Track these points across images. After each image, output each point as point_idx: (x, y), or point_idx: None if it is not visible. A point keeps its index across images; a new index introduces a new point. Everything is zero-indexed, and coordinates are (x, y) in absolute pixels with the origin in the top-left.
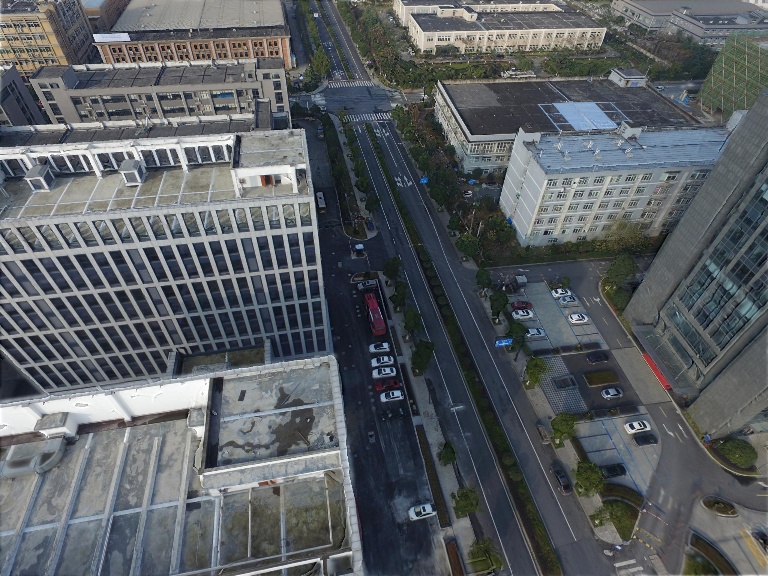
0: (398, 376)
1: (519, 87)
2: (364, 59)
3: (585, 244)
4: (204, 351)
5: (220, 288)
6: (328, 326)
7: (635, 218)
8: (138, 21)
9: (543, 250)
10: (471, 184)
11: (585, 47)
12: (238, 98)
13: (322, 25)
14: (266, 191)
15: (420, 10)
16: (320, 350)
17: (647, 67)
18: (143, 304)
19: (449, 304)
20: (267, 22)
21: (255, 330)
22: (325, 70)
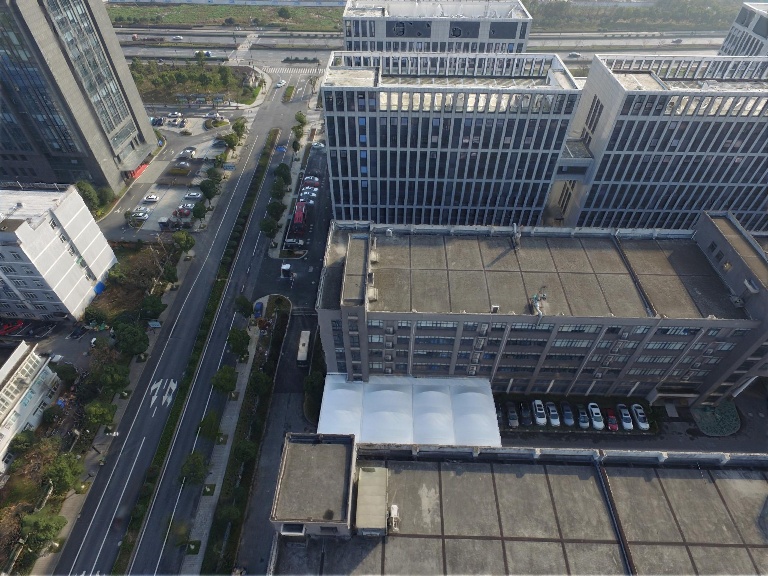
0: None
1: None
2: None
3: None
4: None
5: None
6: None
7: None
8: None
9: None
10: None
11: None
12: None
13: None
14: None
15: None
16: None
17: None
18: None
19: None
20: None
21: None
22: None
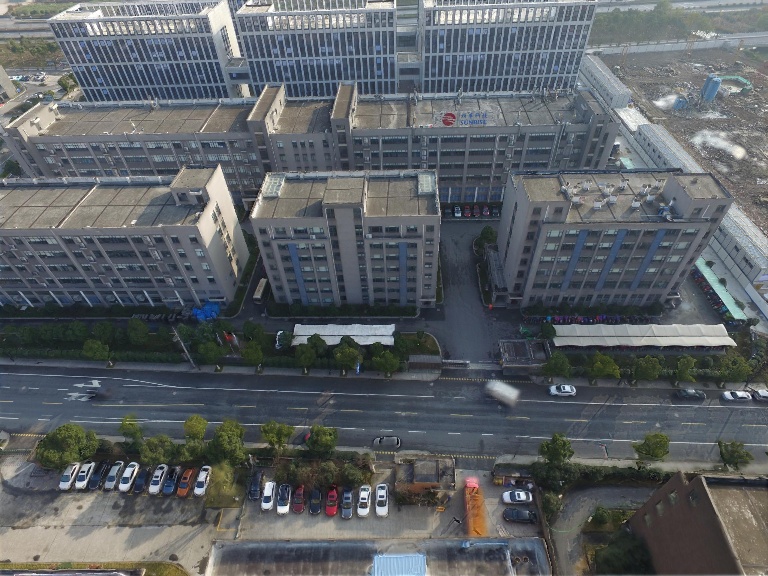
0: None
1: None
2: None
3: None
4: None
5: None
6: None
7: None
8: None
9: None
10: None
11: None
12: None
13: None
14: None
15: None
16: None
17: None
18: None
19: None
20: None
21: None
22: None
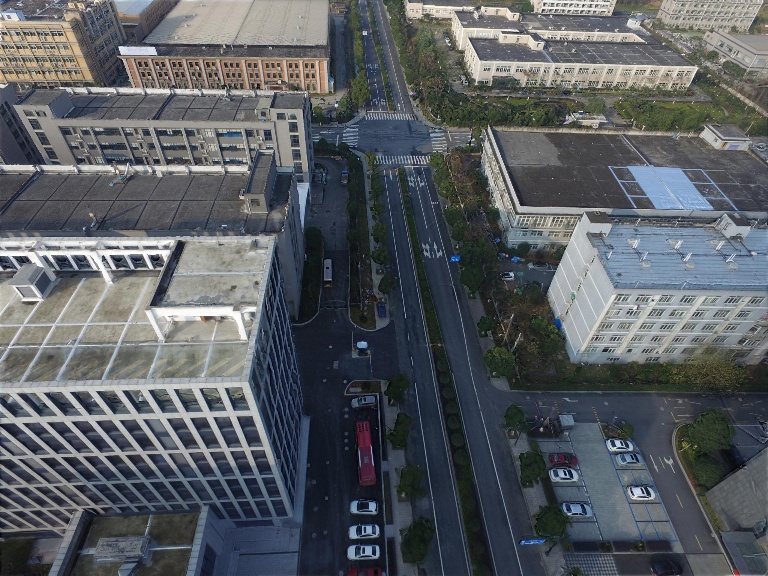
0: (382, 560)
1: (586, 140)
2: (410, 87)
3: (656, 368)
4: (121, 511)
5: (126, 462)
6: (304, 461)
7: (730, 343)
8: (173, 32)
9: (599, 370)
10: (515, 262)
11: (669, 87)
12: (247, 138)
13: (371, 43)
14: (205, 330)
15: (480, 33)
16: (280, 515)
17: (749, 123)
18: (21, 472)
19: (466, 445)
20: (308, 40)
21: (187, 497)
22: (363, 99)
